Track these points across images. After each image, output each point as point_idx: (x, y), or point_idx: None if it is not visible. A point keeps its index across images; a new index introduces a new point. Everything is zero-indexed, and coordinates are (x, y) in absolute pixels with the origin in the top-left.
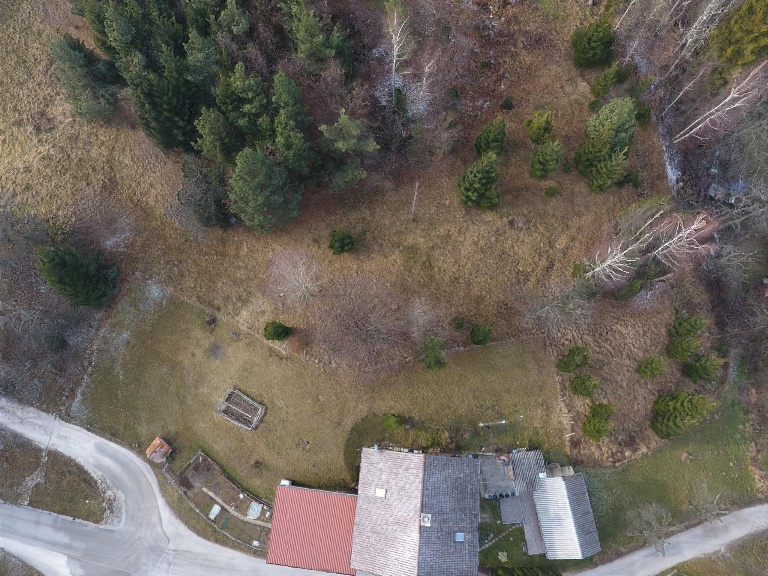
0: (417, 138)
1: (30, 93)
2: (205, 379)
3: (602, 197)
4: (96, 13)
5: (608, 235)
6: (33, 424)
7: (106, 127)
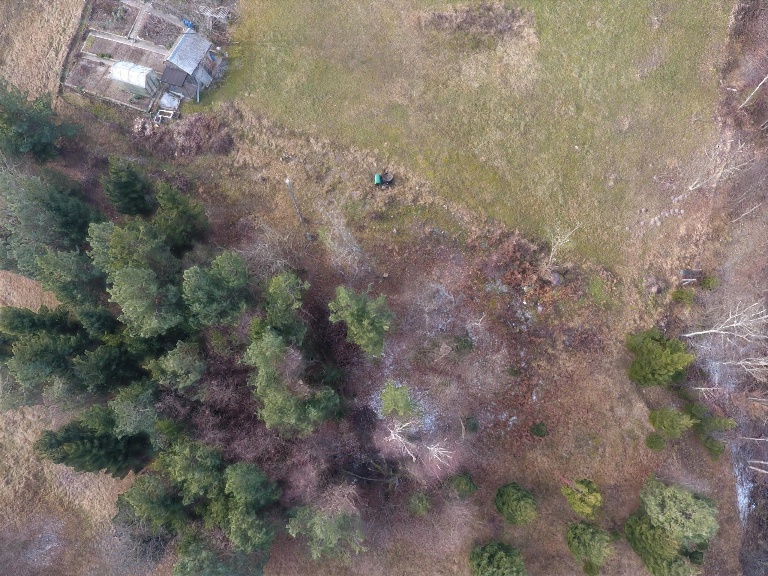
0: None
1: None
2: None
3: None
4: (7, 322)
5: None
6: None
7: None
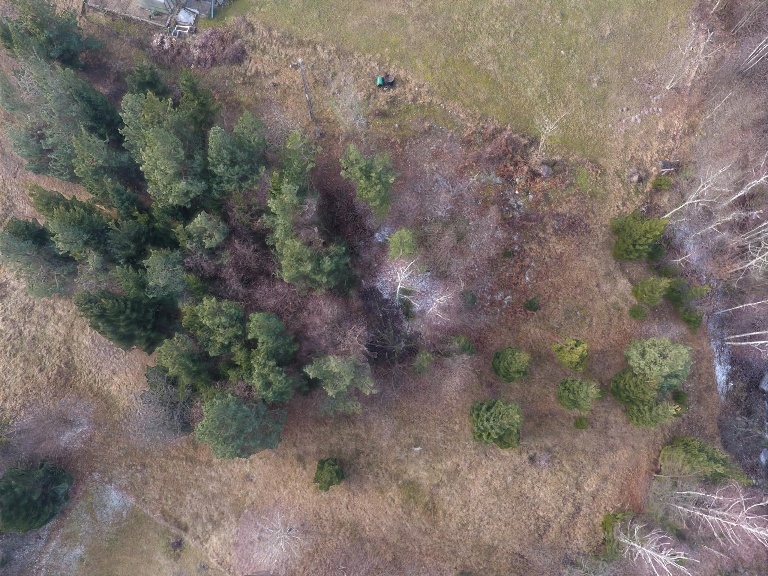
0: None
1: None
2: None
3: (641, 427)
4: (45, 201)
5: (647, 473)
6: None
7: (65, 298)
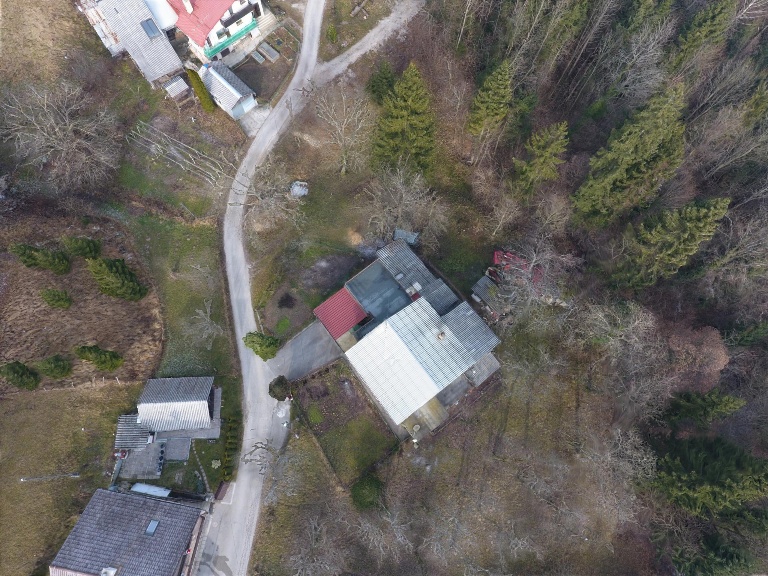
0: None
1: None
2: None
3: None
4: None
5: None
6: None
7: None
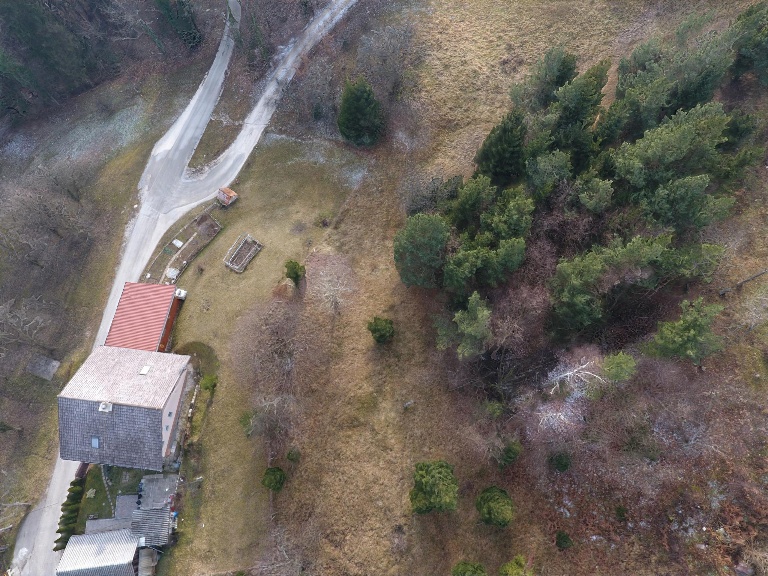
0: None
1: (542, 49)
2: (276, 223)
3: None
4: (597, 73)
5: None
6: (263, 111)
7: None
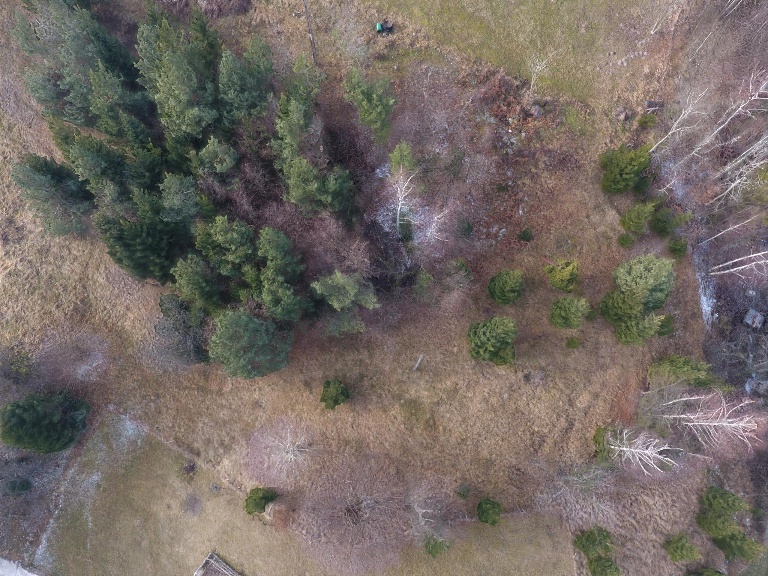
0: (423, 285)
1: None
2: (181, 537)
3: (630, 347)
4: (64, 135)
5: (635, 391)
6: None
7: (80, 240)
